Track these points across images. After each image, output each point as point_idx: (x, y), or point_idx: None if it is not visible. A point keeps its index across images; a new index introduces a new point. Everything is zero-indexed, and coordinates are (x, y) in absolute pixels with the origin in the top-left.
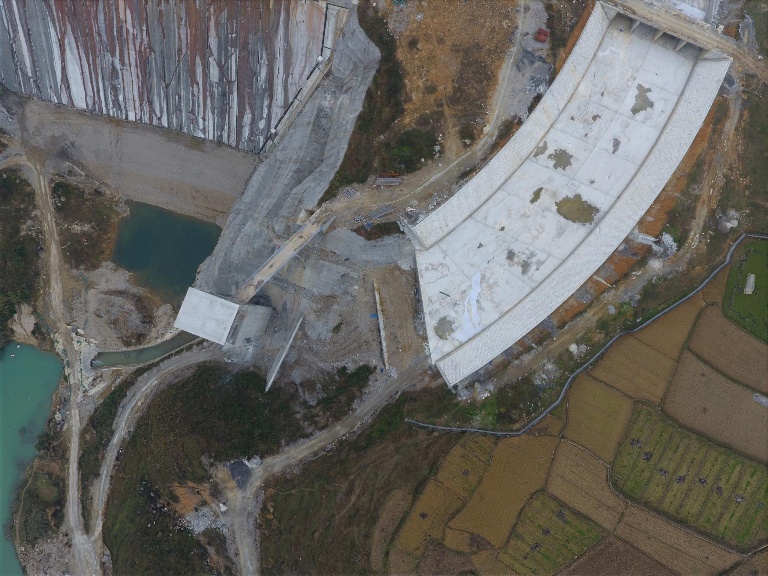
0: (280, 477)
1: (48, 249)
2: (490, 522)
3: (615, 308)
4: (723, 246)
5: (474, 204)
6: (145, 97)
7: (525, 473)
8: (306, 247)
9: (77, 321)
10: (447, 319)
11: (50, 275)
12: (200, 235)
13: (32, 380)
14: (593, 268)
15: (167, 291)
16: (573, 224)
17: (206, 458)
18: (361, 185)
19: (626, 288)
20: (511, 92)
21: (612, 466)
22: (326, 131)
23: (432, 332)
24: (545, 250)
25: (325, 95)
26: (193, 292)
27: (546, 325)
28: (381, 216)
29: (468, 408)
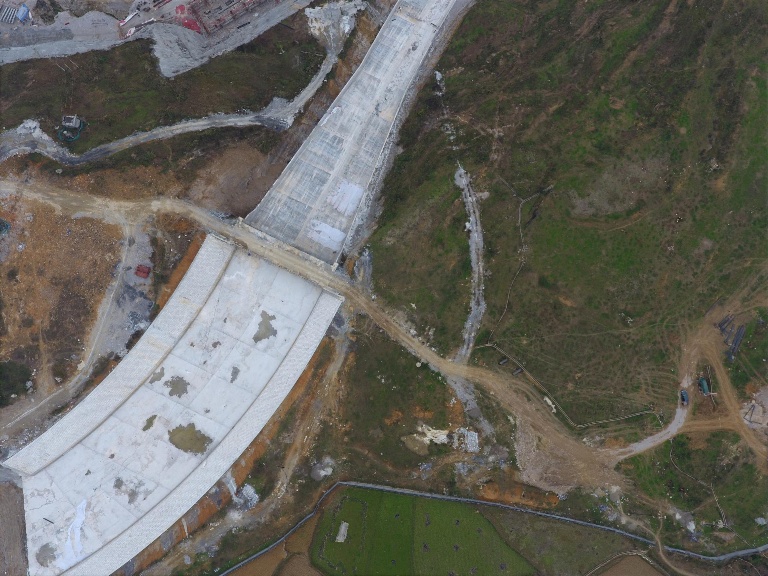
0: None
1: None
2: None
3: (191, 558)
4: (313, 495)
5: (79, 433)
6: None
7: None
8: None
9: None
10: (49, 546)
11: None
12: None
13: None
14: (183, 510)
15: None
16: (184, 454)
17: None
18: None
19: (203, 539)
20: (109, 328)
21: None
22: None
23: (33, 559)
24: (154, 479)
25: None
26: None
27: (127, 569)
28: None
29: None
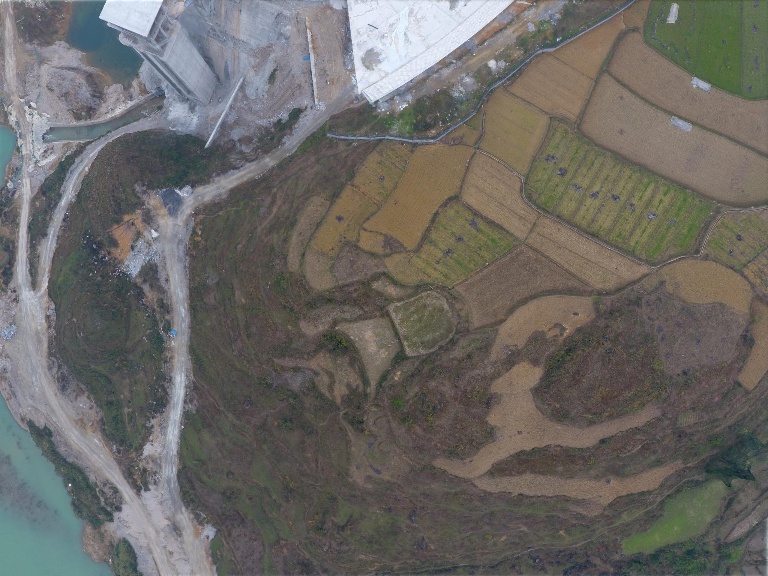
0: (209, 204)
1: (3, 23)
2: (403, 225)
3: (535, 26)
4: None
5: None
6: None
7: (439, 180)
8: None
9: (30, 95)
10: (374, 51)
11: (5, 49)
12: None
13: None
14: None
15: (118, 72)
16: None
17: (139, 186)
18: None
19: (546, 6)
20: None
21: (526, 180)
22: None
23: (359, 63)
24: None
25: None
26: None
27: (467, 45)
28: None
29: (387, 119)
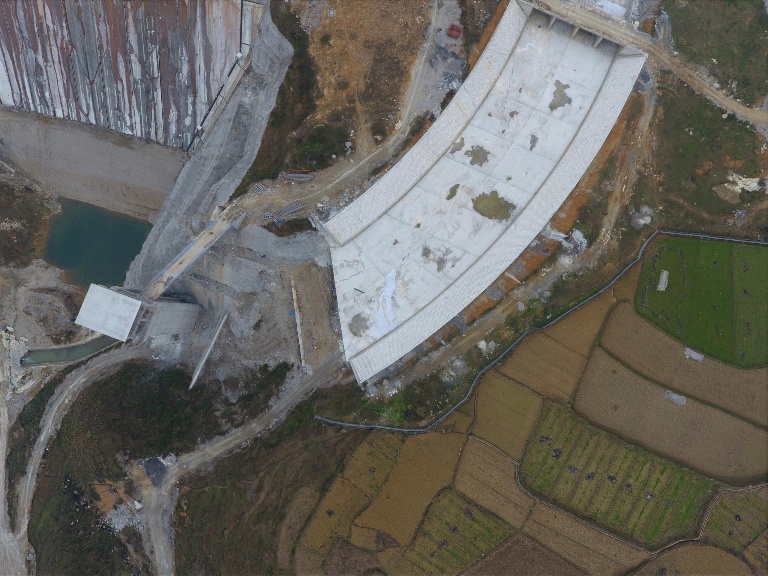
0: (194, 475)
1: None
2: (396, 519)
3: (525, 305)
4: (635, 243)
5: (389, 201)
6: (71, 94)
7: (432, 470)
8: (223, 244)
9: (7, 319)
10: (361, 316)
11: None
12: (133, 232)
13: None
14: (505, 265)
15: None
16: (489, 221)
17: (121, 456)
18: (271, 181)
19: (536, 285)
20: (424, 88)
21: (521, 463)
22: (246, 128)
23: (346, 329)
24: (461, 247)
25: (246, 91)
26: (95, 288)
27: (457, 322)
28: (291, 212)
29: (376, 405)
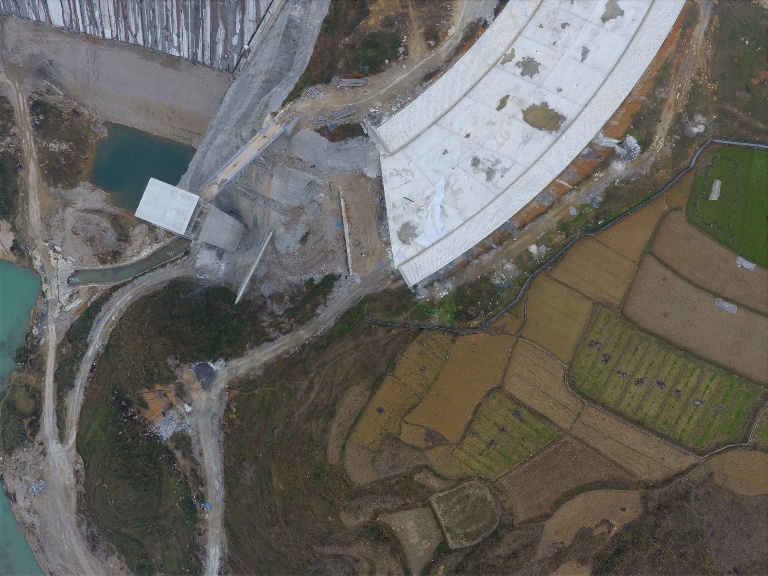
0: (244, 379)
1: (27, 167)
2: (446, 418)
3: (576, 209)
4: (689, 151)
5: (439, 109)
6: (120, 13)
7: (482, 370)
8: (273, 154)
9: (55, 239)
10: (410, 224)
11: (28, 193)
12: (177, 158)
13: (11, 296)
14: (556, 172)
15: None
16: (539, 132)
17: (172, 360)
18: (325, 85)
19: (588, 189)
20: None
21: (570, 367)
22: (296, 41)
23: (395, 237)
24: (510, 157)
25: (295, 6)
26: (154, 183)
27: (507, 227)
28: (344, 117)
29: (427, 306)
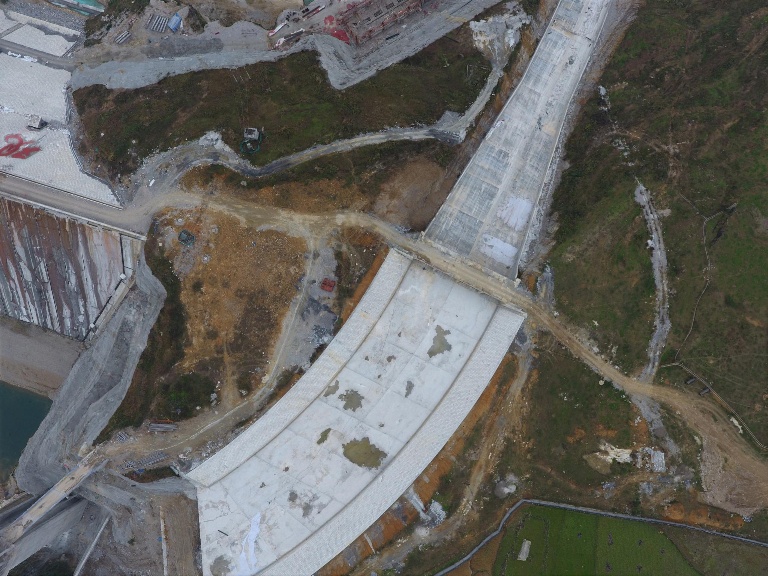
0: None
1: None
2: None
3: (378, 575)
4: (497, 513)
5: (256, 446)
6: None
7: None
8: None
9: None
10: (224, 558)
11: None
12: (34, 406)
13: None
14: (365, 525)
15: None
16: (359, 468)
17: None
18: (134, 431)
19: (390, 555)
20: (293, 341)
21: None
22: (128, 346)
23: (208, 571)
24: (328, 493)
25: (130, 309)
26: None
27: None
28: (153, 463)
29: None
